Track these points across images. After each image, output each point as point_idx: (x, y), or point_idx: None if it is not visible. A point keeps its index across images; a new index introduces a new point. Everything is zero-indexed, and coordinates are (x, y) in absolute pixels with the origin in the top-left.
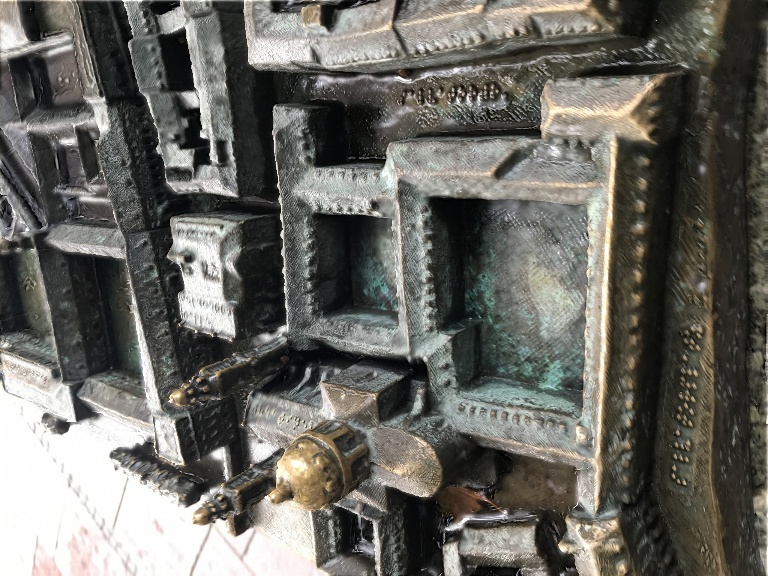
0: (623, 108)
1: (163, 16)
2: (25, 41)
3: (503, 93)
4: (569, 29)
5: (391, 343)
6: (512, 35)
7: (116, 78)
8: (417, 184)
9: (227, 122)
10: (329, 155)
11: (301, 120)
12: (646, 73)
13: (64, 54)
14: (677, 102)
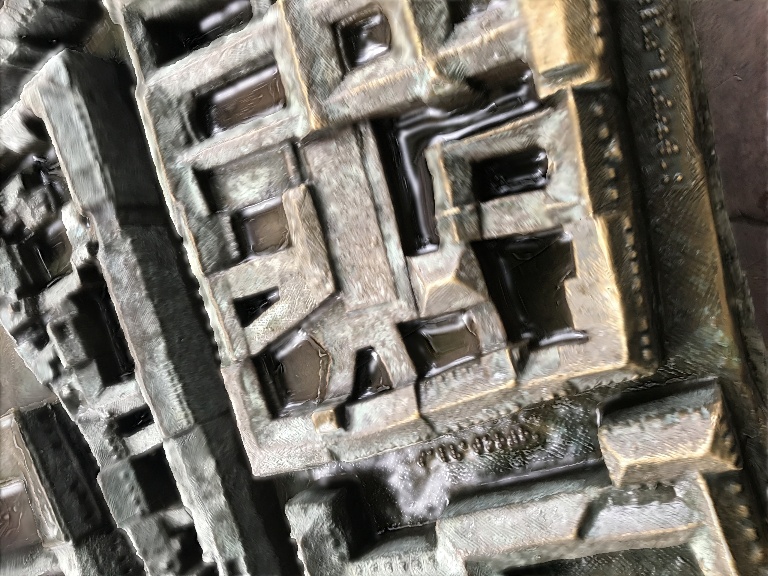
0: (701, 448)
1: (131, 438)
2: None
3: (534, 434)
4: (608, 382)
5: None
6: (551, 398)
7: (80, 512)
8: (487, 561)
9: (233, 537)
10: (359, 540)
11: (324, 516)
12: (680, 391)
13: (1, 489)
14: (728, 414)
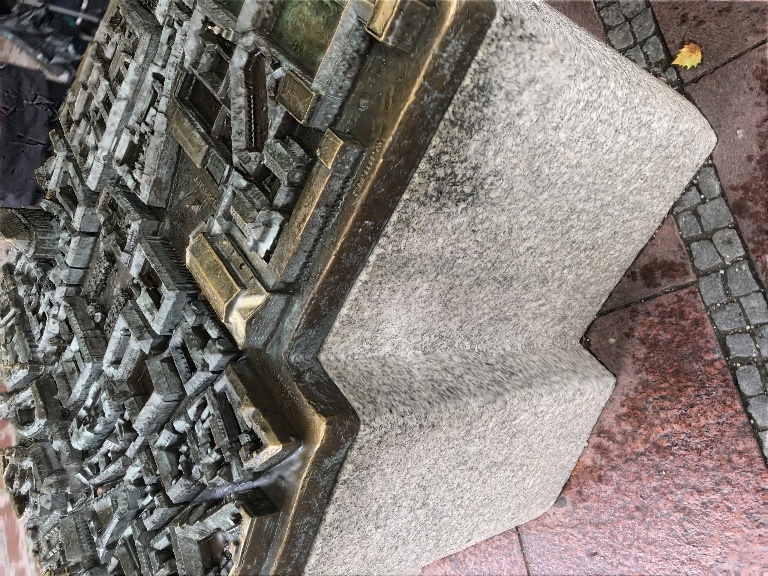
0: None
1: None
2: (179, 109)
3: None
4: None
5: None
6: (124, 0)
7: None
8: None
9: None
10: None
11: None
12: None
13: None
14: None
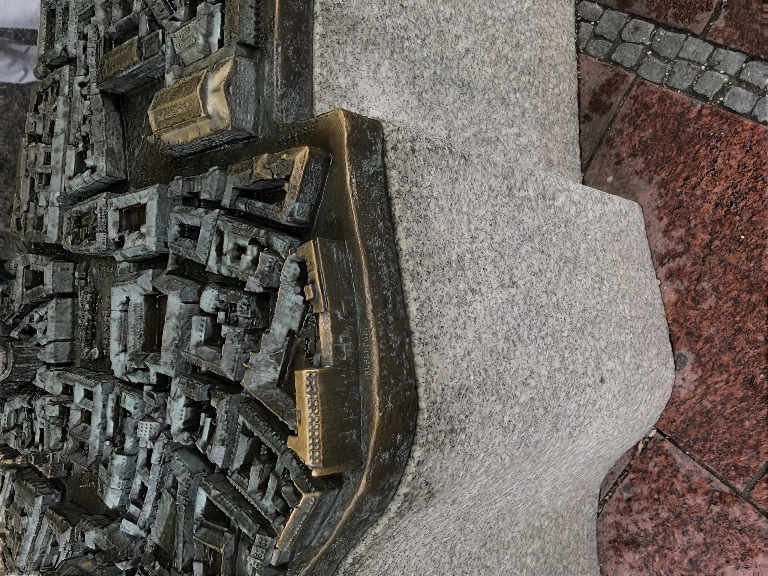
0: None
1: None
2: None
3: None
4: None
5: (61, 2)
6: None
7: None
8: None
9: None
10: None
11: None
12: None
13: None
14: None
